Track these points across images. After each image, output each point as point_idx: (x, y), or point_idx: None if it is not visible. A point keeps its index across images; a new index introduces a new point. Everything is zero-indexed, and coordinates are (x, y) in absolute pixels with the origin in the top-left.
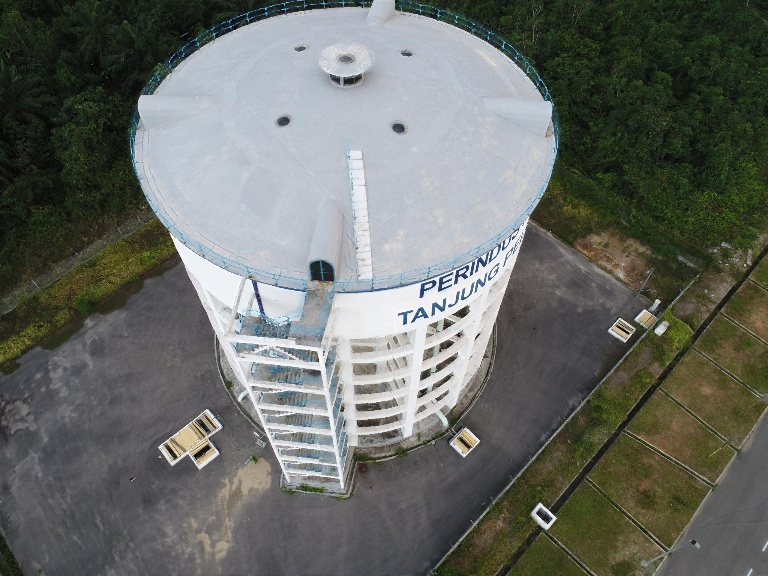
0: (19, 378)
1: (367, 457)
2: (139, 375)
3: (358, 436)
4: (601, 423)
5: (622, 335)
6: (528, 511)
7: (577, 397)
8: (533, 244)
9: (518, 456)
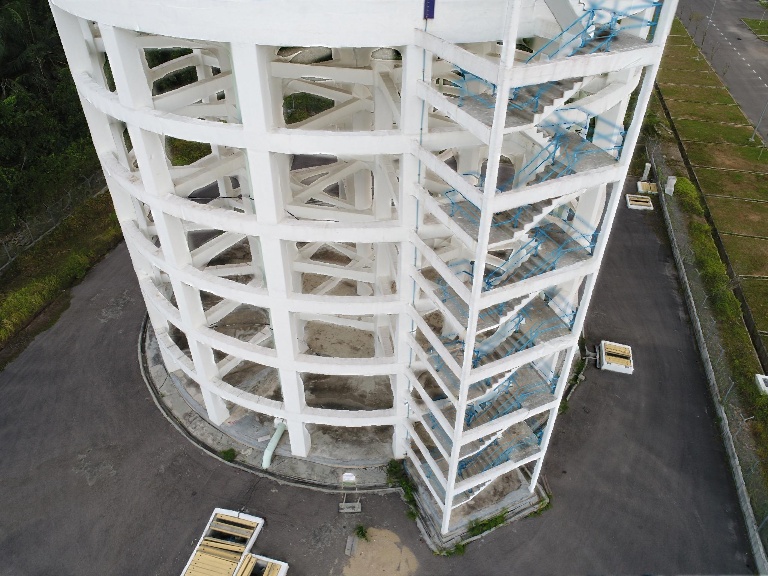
0: None
1: None
2: (35, 529)
3: None
4: (713, 278)
5: (644, 205)
6: (755, 391)
7: (667, 267)
8: None
9: (681, 343)
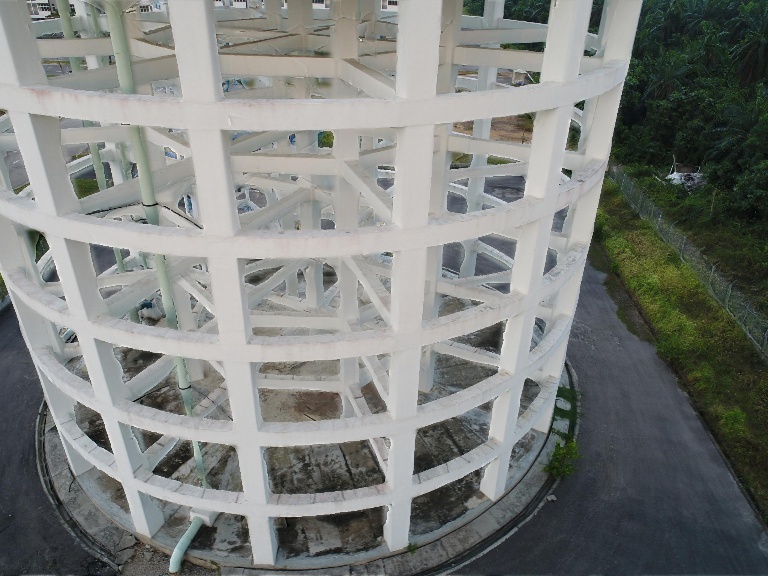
0: None
1: None
2: None
3: None
4: None
5: None
6: None
7: None
8: None
9: None
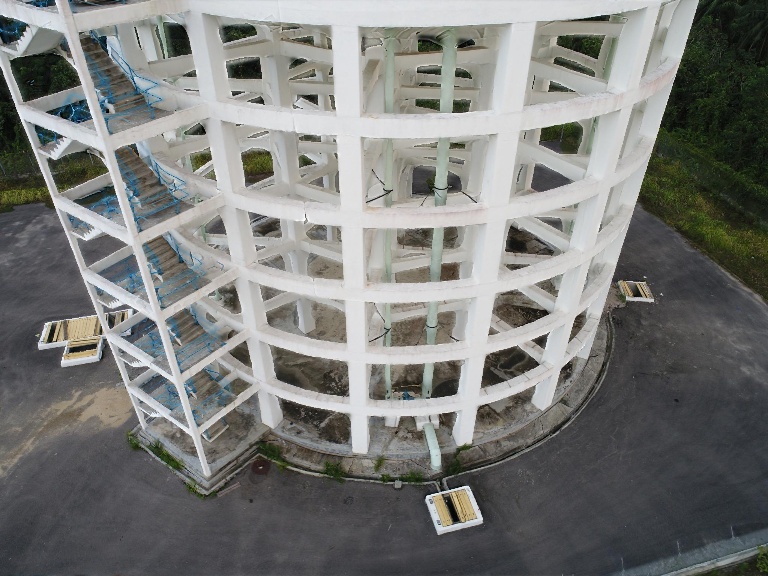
0: (0, 219)
1: (278, 453)
2: (101, 255)
3: (285, 416)
4: None
5: None
6: None
7: (728, 542)
8: (722, 299)
9: None
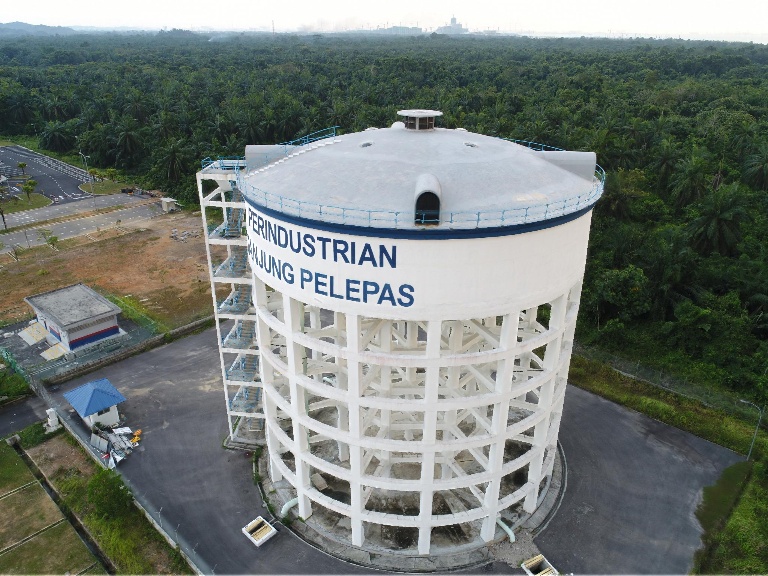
0: None
1: (258, 455)
2: None
3: None
4: None
5: None
6: None
7: None
8: None
9: None
